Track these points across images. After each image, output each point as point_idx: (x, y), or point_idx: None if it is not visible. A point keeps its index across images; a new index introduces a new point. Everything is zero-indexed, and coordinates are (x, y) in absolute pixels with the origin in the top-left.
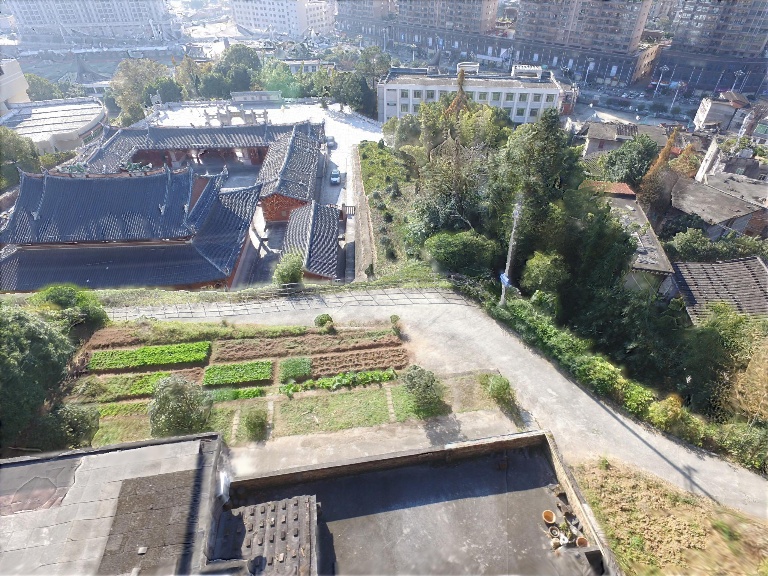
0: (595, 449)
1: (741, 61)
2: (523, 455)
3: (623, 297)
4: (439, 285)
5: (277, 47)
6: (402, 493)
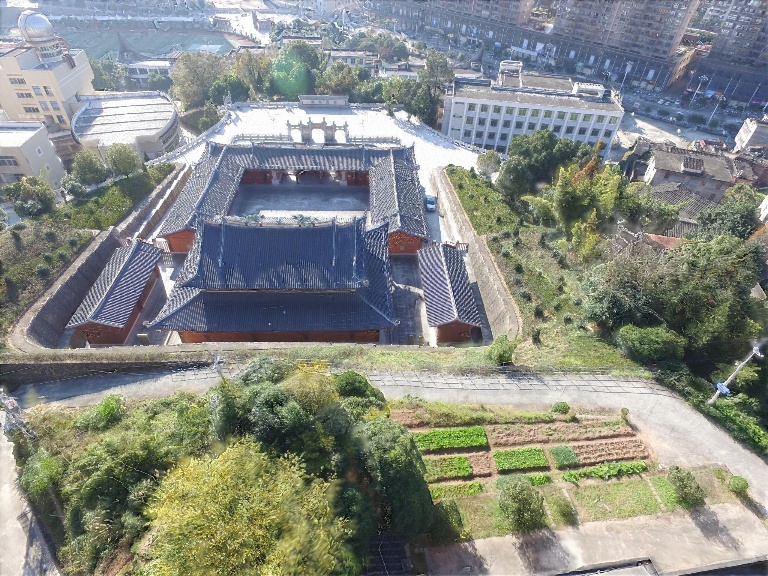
0: None
1: None
2: None
3: None
4: (643, 375)
5: None
6: None
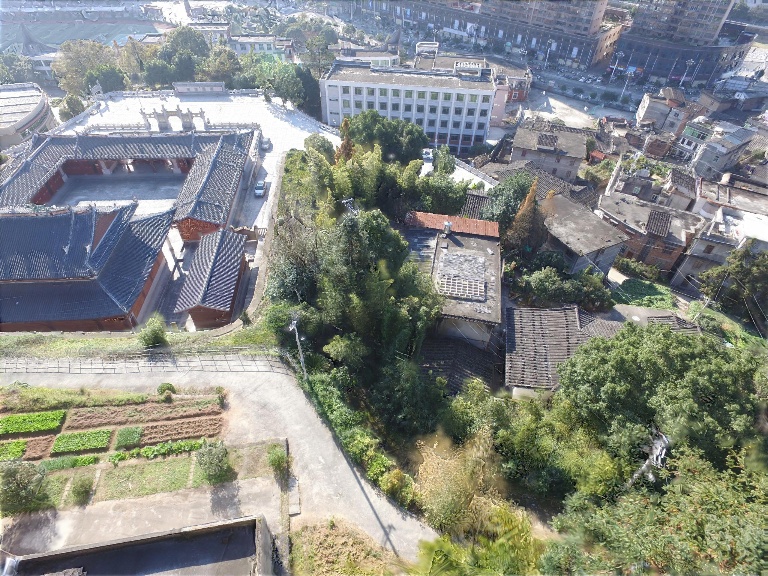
0: (332, 510)
1: (694, 49)
2: (244, 531)
3: (398, 376)
4: (270, 353)
5: (231, 22)
6: (147, 563)
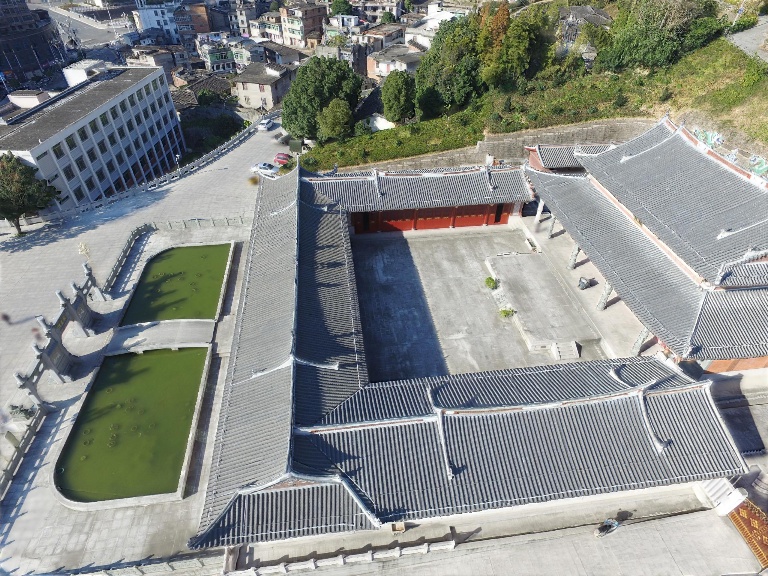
0: None
1: (35, 32)
2: None
3: None
4: None
5: None
6: None
